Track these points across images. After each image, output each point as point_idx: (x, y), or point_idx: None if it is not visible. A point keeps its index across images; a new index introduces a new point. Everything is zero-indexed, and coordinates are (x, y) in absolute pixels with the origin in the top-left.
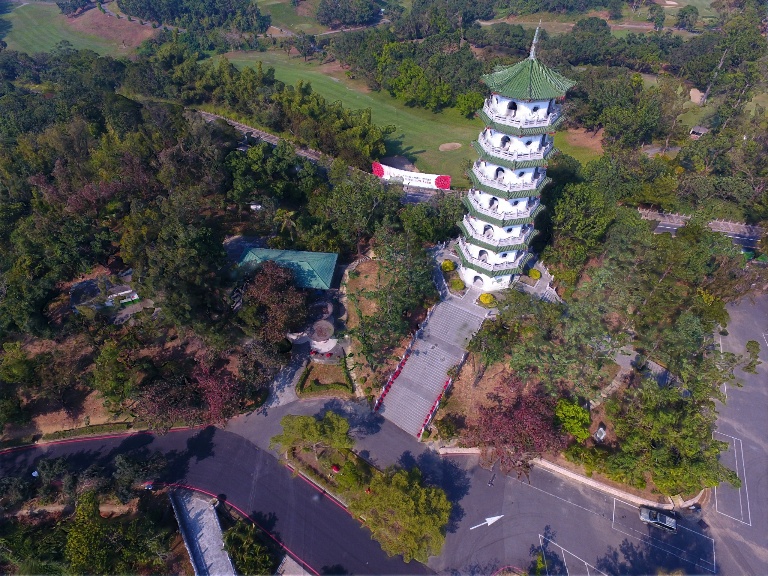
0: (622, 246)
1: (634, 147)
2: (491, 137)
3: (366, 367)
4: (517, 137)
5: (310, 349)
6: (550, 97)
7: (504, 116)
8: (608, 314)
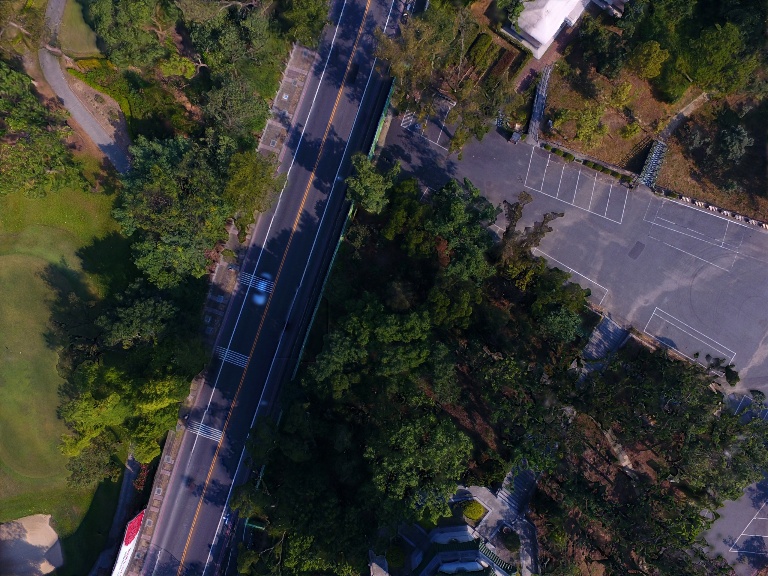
0: None
1: (60, 123)
2: None
3: None
4: None
5: None
6: None
7: None
8: (506, 392)
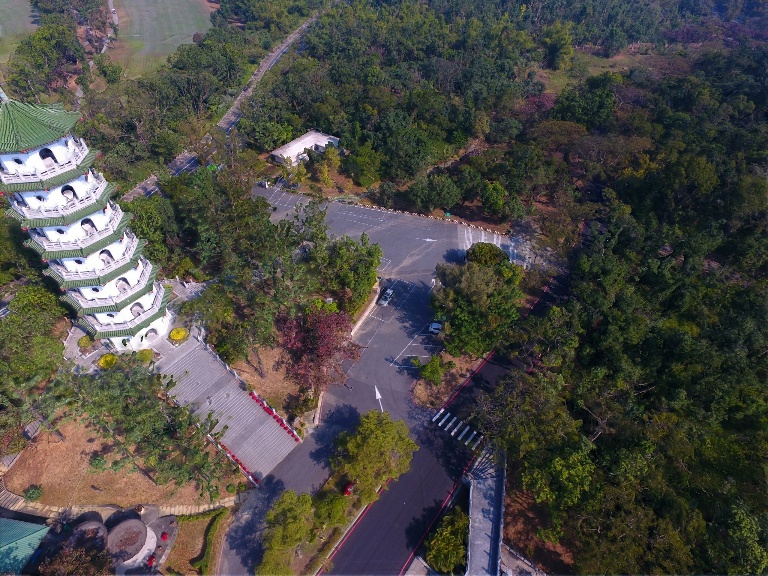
0: (183, 215)
1: None
2: (45, 201)
3: (199, 489)
4: (77, 179)
5: (142, 567)
6: (74, 123)
7: (49, 168)
8: (223, 265)
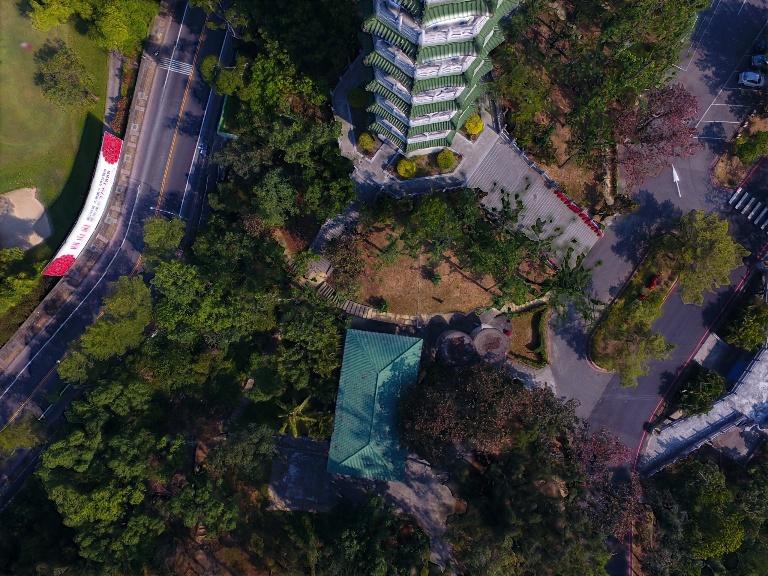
0: None
1: None
2: None
3: None
4: None
5: None
6: None
7: None
8: None
